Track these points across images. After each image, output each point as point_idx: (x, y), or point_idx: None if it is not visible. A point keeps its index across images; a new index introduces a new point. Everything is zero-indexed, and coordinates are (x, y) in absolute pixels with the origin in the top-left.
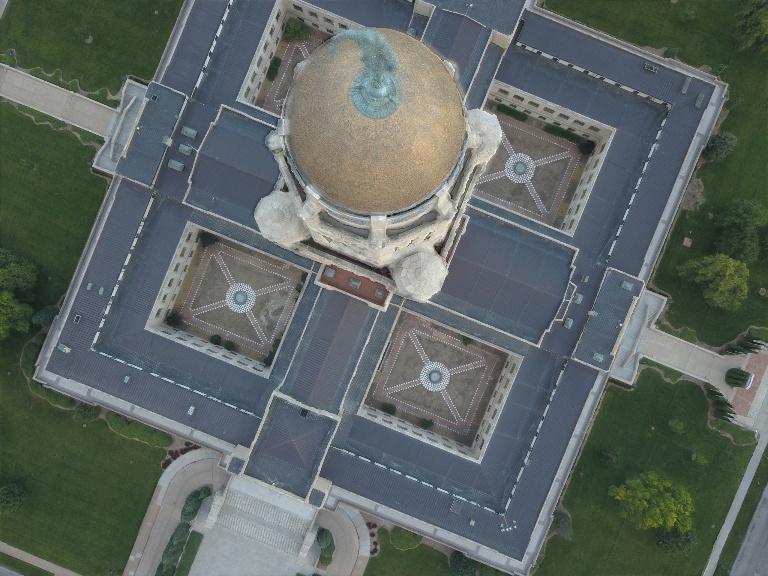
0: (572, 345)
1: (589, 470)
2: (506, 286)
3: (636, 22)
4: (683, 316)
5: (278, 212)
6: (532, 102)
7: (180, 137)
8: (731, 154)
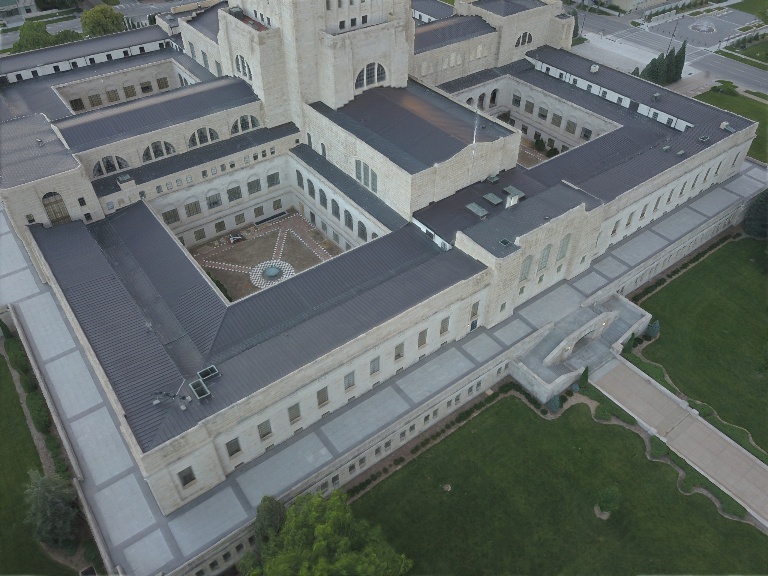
0: None
1: None
2: None
3: None
4: None
5: None
6: None
7: None
8: None
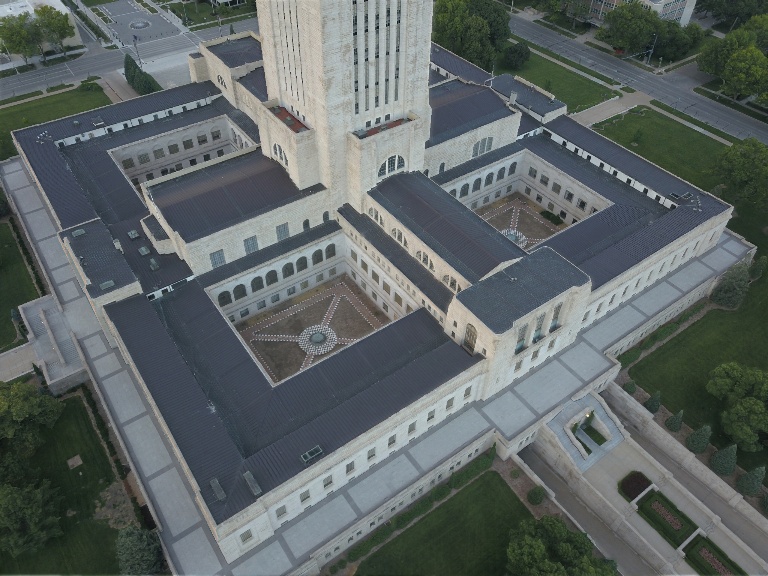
0: (113, 234)
1: (2, 252)
2: (215, 184)
3: None
4: None
5: None
6: None
7: None
8: None
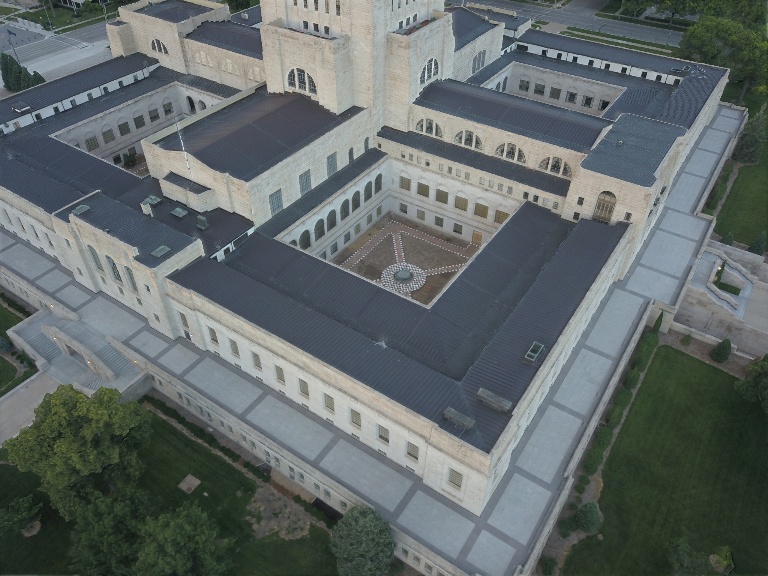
0: None
1: None
2: None
3: (653, 474)
4: None
5: None
6: None
7: None
8: None
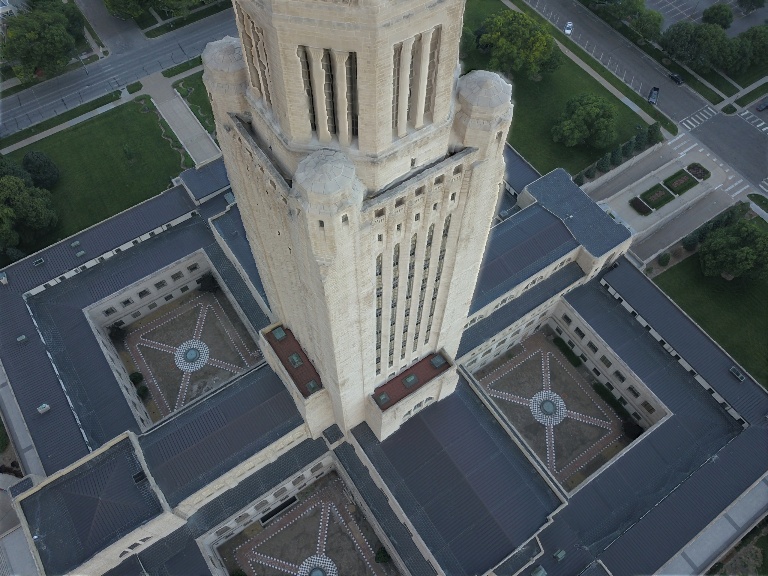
0: None
1: None
2: (458, 488)
3: (738, 346)
4: None
5: (230, 47)
6: (592, 344)
7: None
8: None
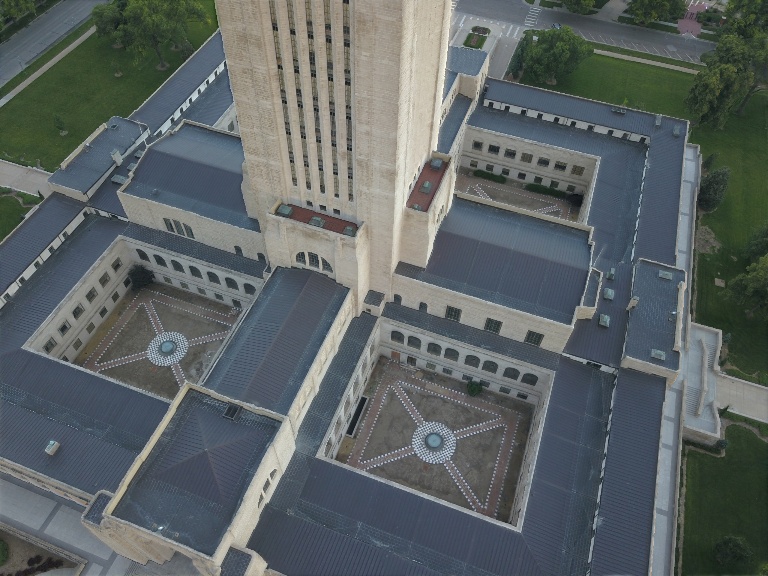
0: (618, 350)
1: None
2: (513, 260)
3: None
4: (751, 359)
5: None
6: (508, 151)
7: (132, 160)
8: (729, 207)
